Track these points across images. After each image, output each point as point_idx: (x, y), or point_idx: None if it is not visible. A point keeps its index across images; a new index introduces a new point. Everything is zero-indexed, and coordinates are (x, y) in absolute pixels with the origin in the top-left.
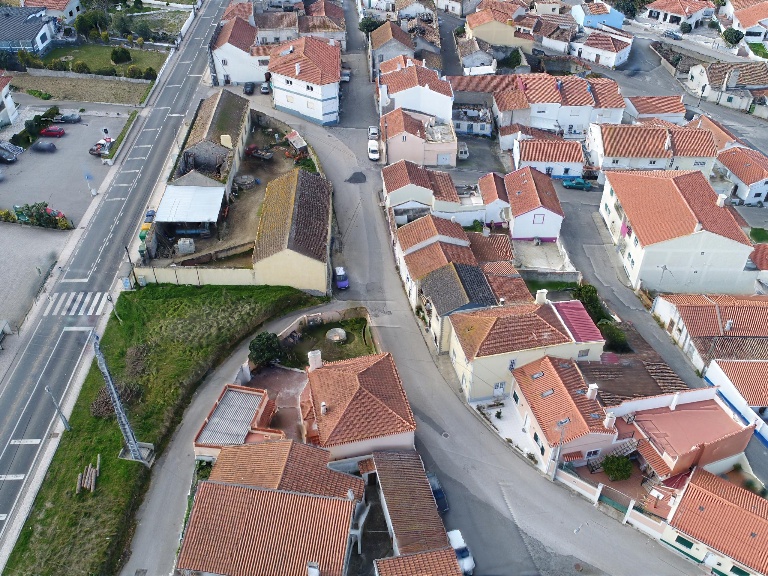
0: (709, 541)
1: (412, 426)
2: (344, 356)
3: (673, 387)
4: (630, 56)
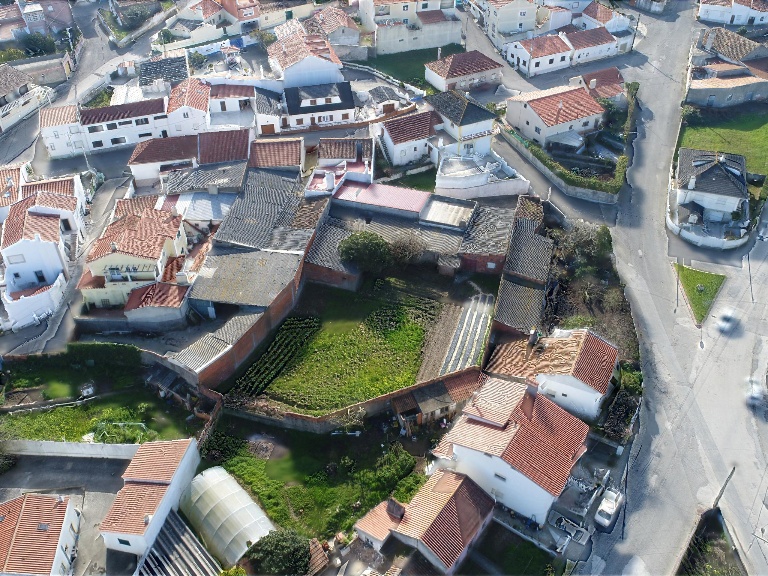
0: None
1: None
2: None
3: (270, 7)
4: (743, 25)
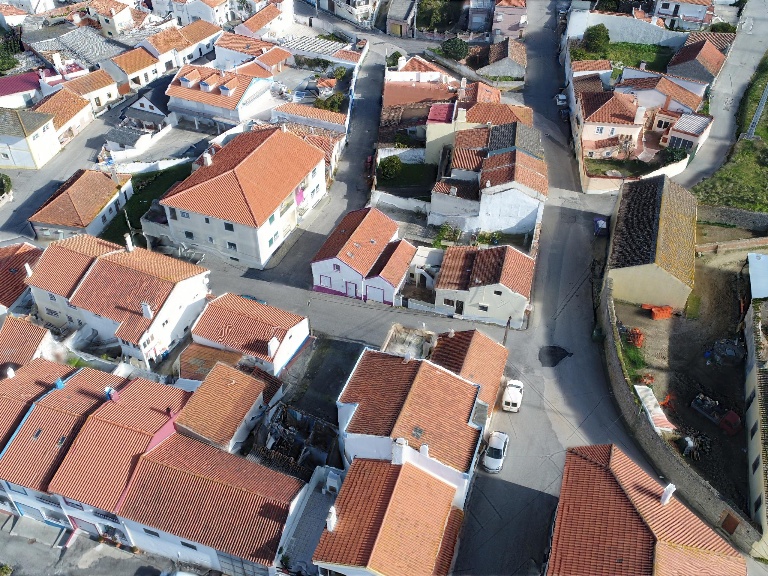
0: (444, 72)
1: (582, 91)
2: (610, 165)
3: None
4: None
